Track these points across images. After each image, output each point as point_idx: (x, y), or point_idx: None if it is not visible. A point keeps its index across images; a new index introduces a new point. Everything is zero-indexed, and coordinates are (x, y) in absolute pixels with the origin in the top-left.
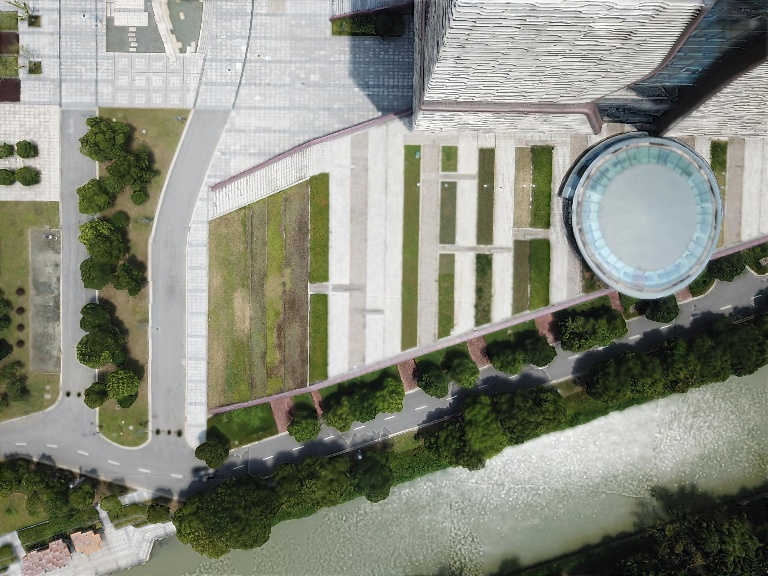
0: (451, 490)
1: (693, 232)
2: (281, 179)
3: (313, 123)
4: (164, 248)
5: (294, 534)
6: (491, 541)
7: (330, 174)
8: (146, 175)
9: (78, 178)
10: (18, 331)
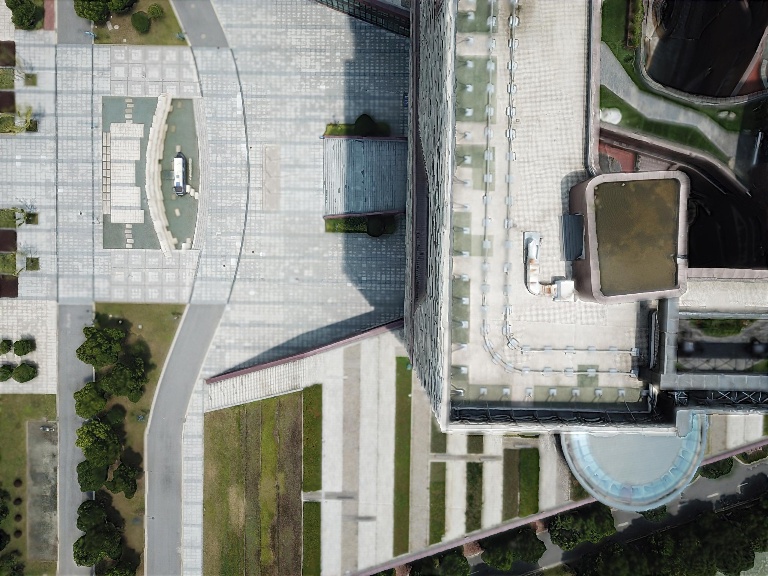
0: None
1: (679, 448)
2: (275, 385)
3: (307, 317)
4: (160, 439)
5: None
6: None
7: (323, 385)
8: (142, 383)
9: (75, 371)
10: (15, 521)
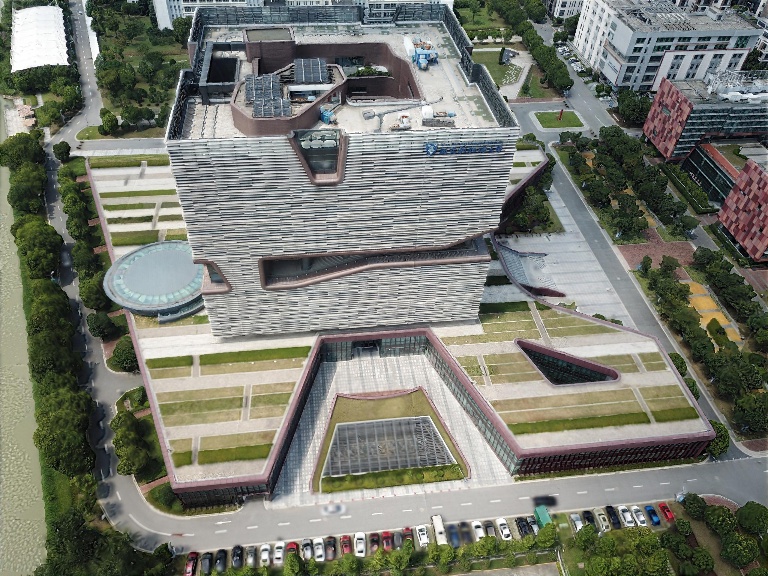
0: None
1: (147, 294)
2: None
3: None
4: None
5: None
6: None
7: None
8: None
9: None
10: (147, 105)
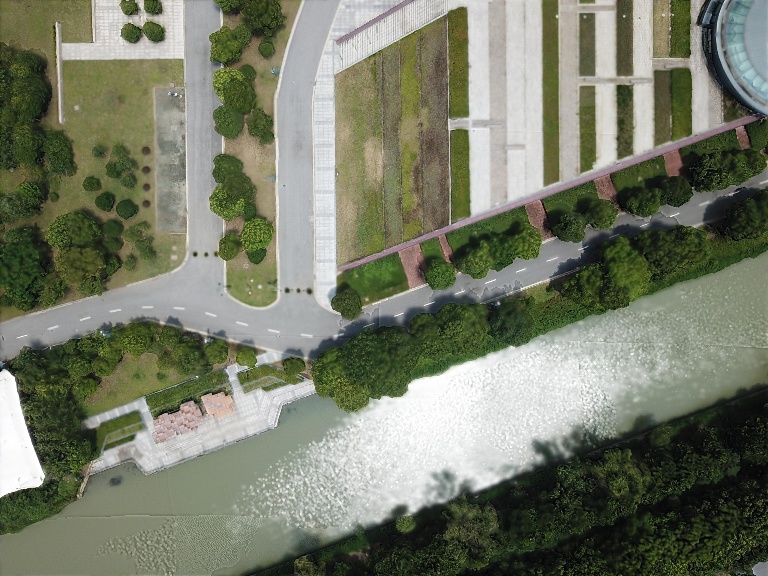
0: (579, 350)
1: None
2: (415, 20)
3: None
4: (290, 103)
5: (419, 402)
6: (623, 399)
7: (468, 9)
8: (281, 17)
9: (202, 35)
10: (144, 191)
